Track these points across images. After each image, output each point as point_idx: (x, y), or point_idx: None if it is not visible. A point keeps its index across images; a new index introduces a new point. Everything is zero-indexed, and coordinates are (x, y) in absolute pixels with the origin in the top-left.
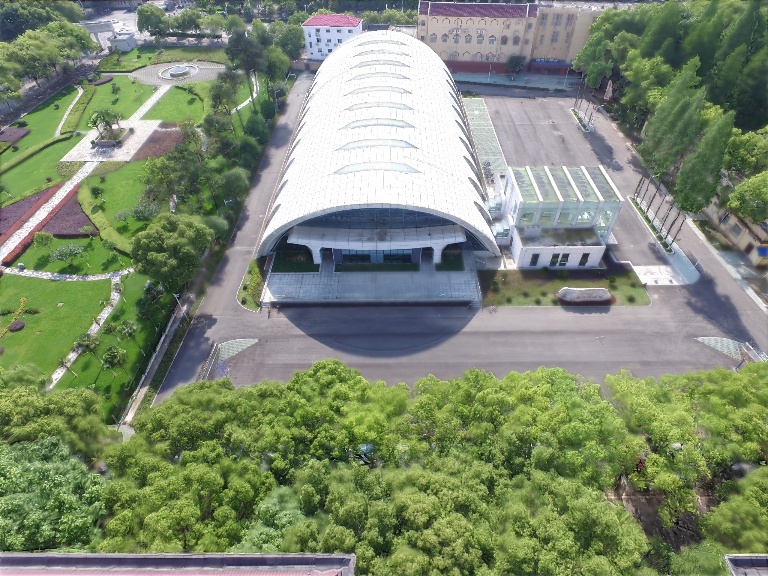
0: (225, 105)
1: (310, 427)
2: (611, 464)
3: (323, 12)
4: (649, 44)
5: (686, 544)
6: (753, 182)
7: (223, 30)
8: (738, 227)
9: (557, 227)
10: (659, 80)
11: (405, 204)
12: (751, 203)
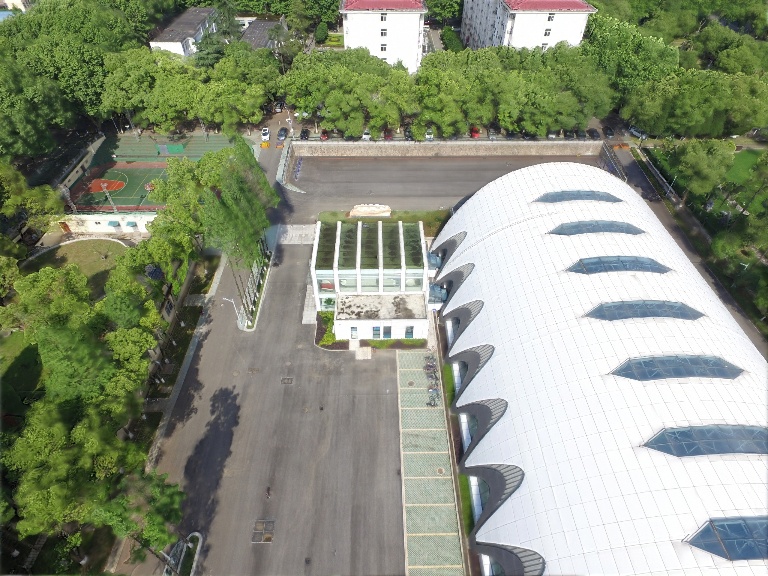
0: None
1: None
2: None
3: None
4: None
5: None
6: None
7: None
8: None
9: None
10: None
11: None
12: None
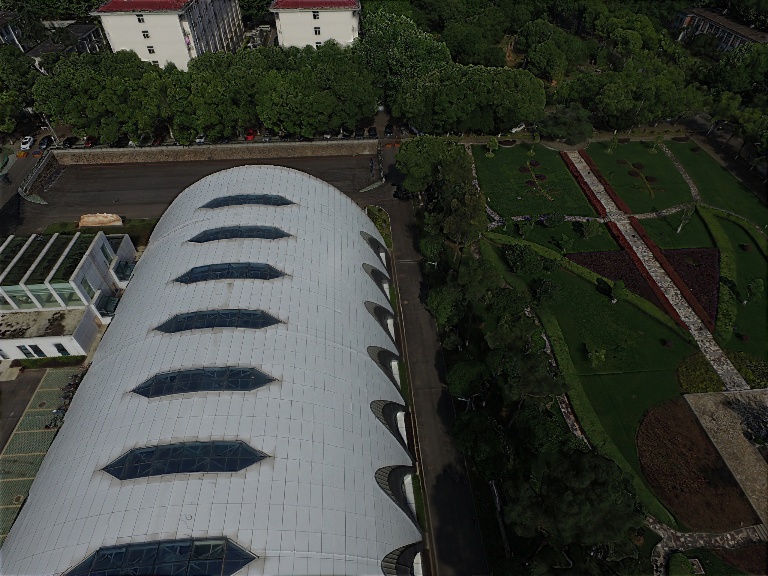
0: None
1: None
2: None
3: None
4: None
5: None
6: None
7: None
8: None
9: None
10: None
11: None
12: None
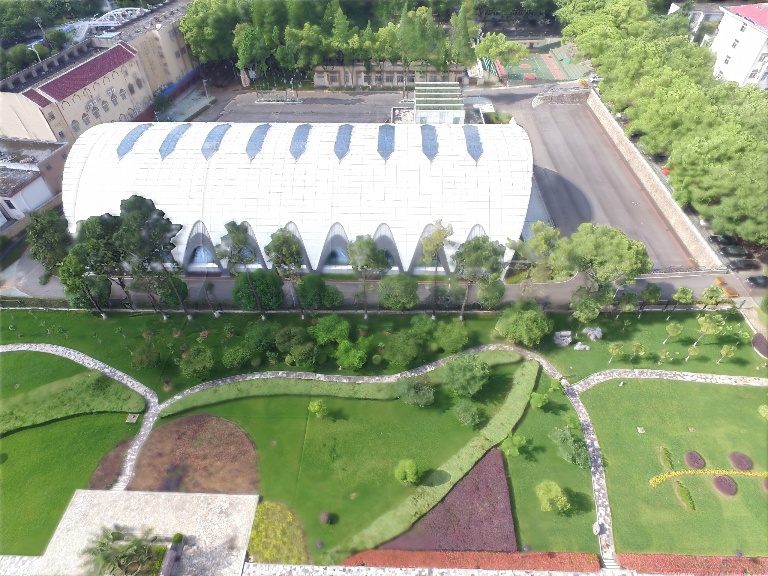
0: None
1: None
2: None
3: None
4: (274, 22)
5: None
6: None
7: None
8: (445, 76)
9: None
10: None
11: None
12: None
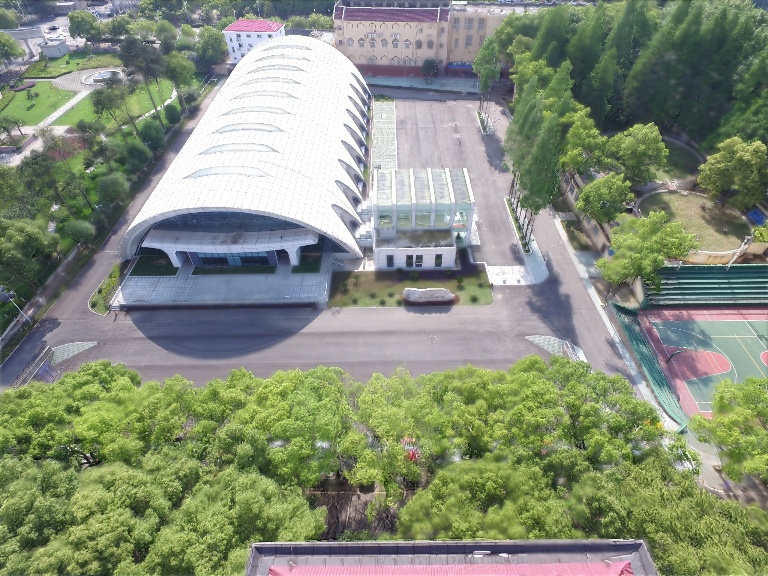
0: (110, 111)
1: (39, 427)
2: (320, 460)
3: (249, 17)
4: (539, 47)
5: (380, 537)
6: (594, 183)
7: (153, 36)
8: (597, 227)
9: (416, 229)
10: (543, 83)
11: (239, 207)
12: (596, 204)
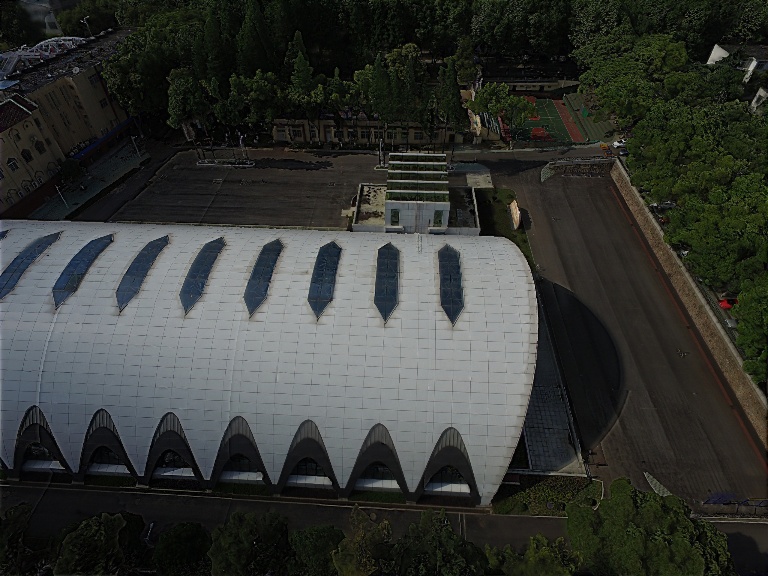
0: None
1: None
2: None
3: None
4: (219, 67)
5: None
6: None
7: None
8: None
9: None
10: None
11: None
12: None
